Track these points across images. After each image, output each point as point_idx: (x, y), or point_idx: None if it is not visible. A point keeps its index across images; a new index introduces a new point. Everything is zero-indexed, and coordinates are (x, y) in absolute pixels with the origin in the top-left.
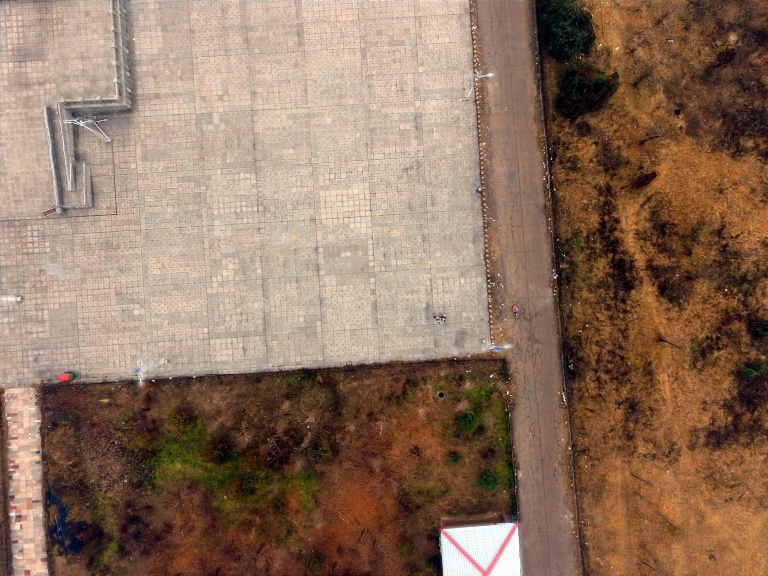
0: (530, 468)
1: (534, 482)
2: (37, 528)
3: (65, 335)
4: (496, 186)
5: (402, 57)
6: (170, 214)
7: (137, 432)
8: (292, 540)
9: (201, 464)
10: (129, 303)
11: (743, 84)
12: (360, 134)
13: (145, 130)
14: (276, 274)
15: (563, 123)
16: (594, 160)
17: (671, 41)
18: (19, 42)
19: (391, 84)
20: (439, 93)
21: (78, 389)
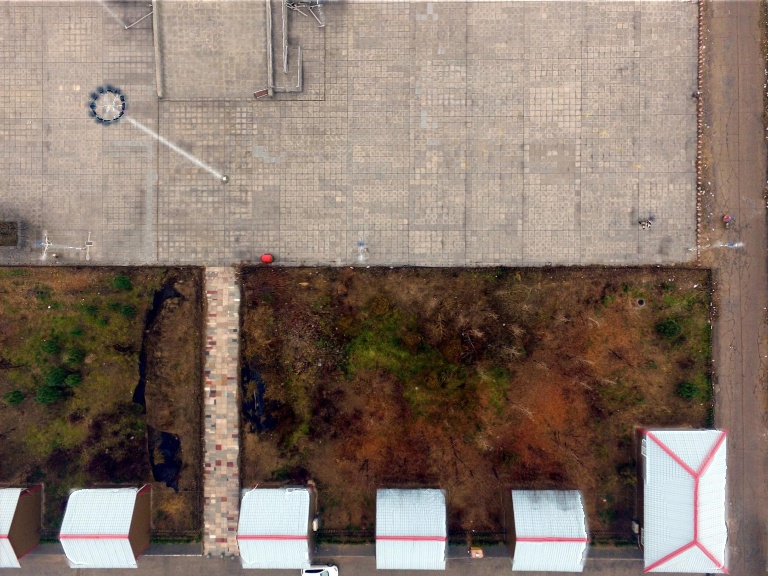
0: (729, 383)
1: (732, 397)
2: (230, 404)
3: (267, 217)
4: (713, 91)
5: None
6: (378, 103)
7: (334, 317)
8: (481, 436)
9: (395, 353)
10: (331, 190)
11: None
12: (575, 31)
13: (358, 17)
14: (480, 169)
15: None
16: None
17: None
18: None
19: None
20: None
21: (277, 271)
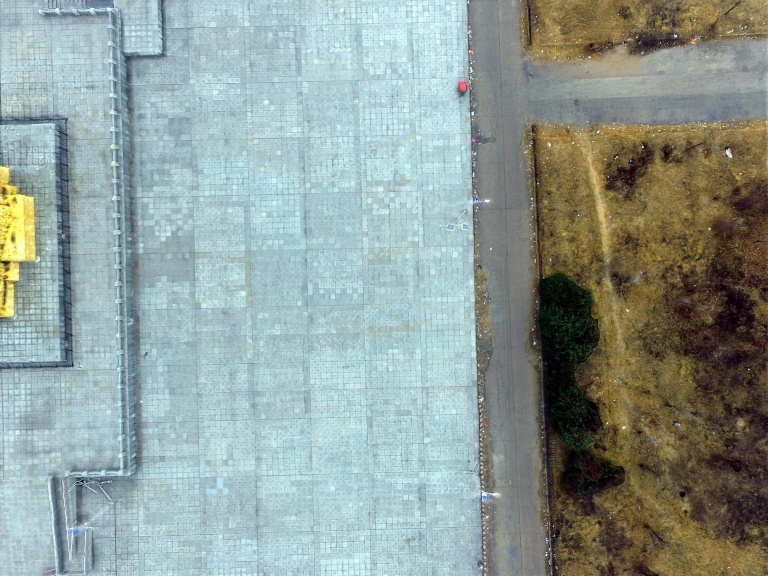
0: None
1: None
2: None
3: None
4: (498, 560)
5: (408, 427)
6: None
7: None
8: None
9: None
10: None
11: (749, 471)
12: (363, 503)
13: (148, 493)
14: None
15: (567, 500)
16: (597, 539)
17: (678, 425)
18: (26, 410)
19: (396, 454)
20: (444, 464)
21: None
